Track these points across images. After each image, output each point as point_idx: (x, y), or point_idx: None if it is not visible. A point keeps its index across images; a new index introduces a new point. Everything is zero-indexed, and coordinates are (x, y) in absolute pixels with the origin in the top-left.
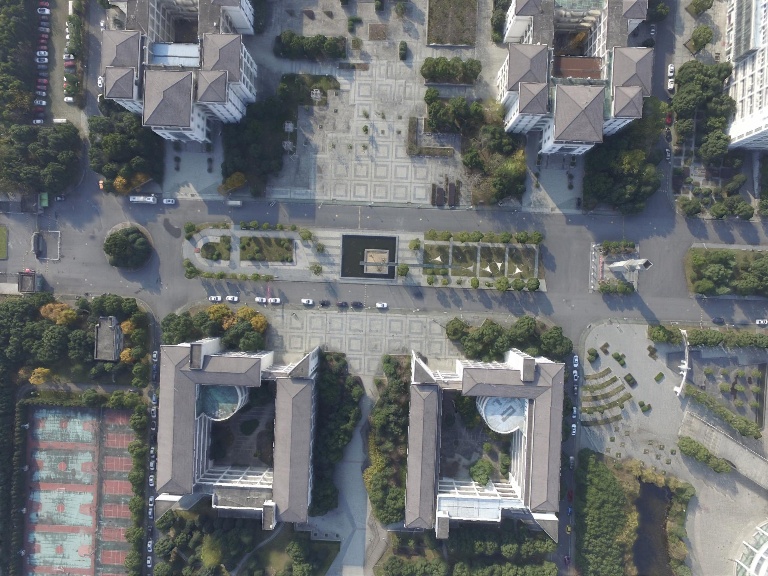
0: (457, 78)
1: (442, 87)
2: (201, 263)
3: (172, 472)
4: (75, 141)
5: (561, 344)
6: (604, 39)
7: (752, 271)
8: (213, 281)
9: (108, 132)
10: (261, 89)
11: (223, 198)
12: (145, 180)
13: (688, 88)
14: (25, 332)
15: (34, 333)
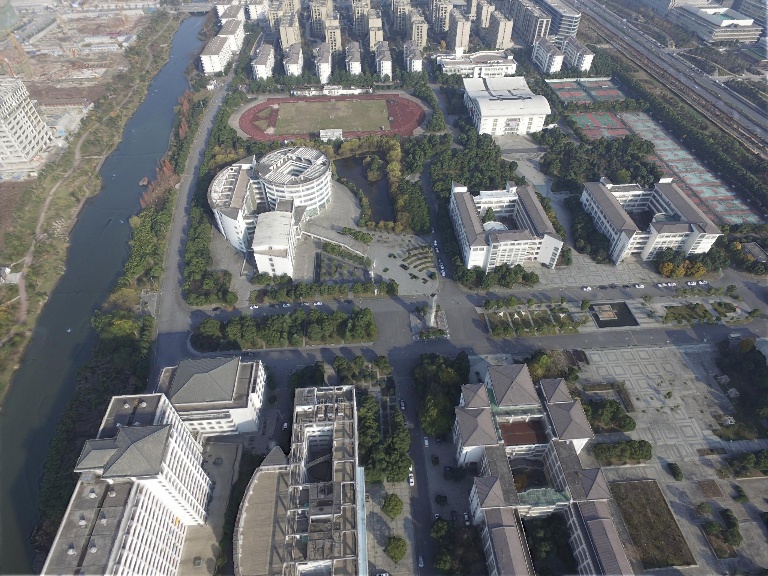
0: None
1: None
2: (729, 300)
3: (673, 187)
4: None
5: (464, 270)
6: None
7: (332, 325)
8: None
9: None
10: None
11: None
12: None
13: None
14: None
15: None
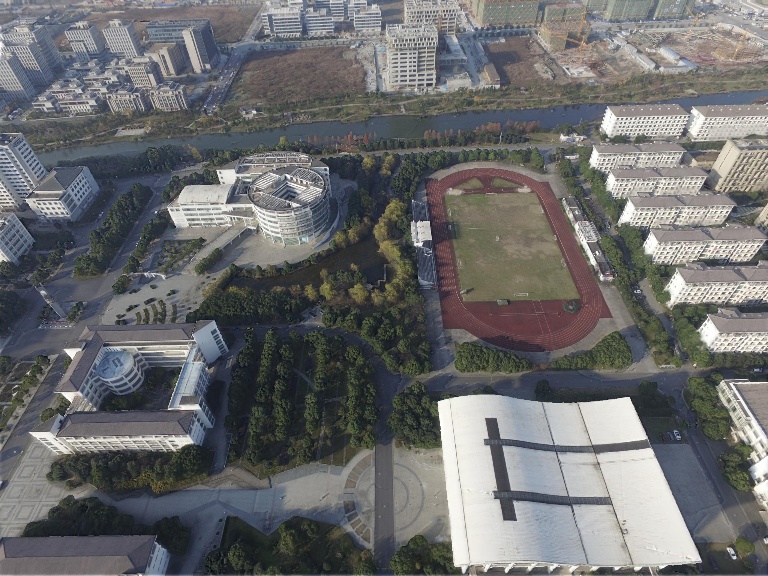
0: None
1: None
2: None
3: None
4: None
5: None
6: None
7: None
8: None
9: None
10: None
11: None
12: None
13: None
14: None
15: None
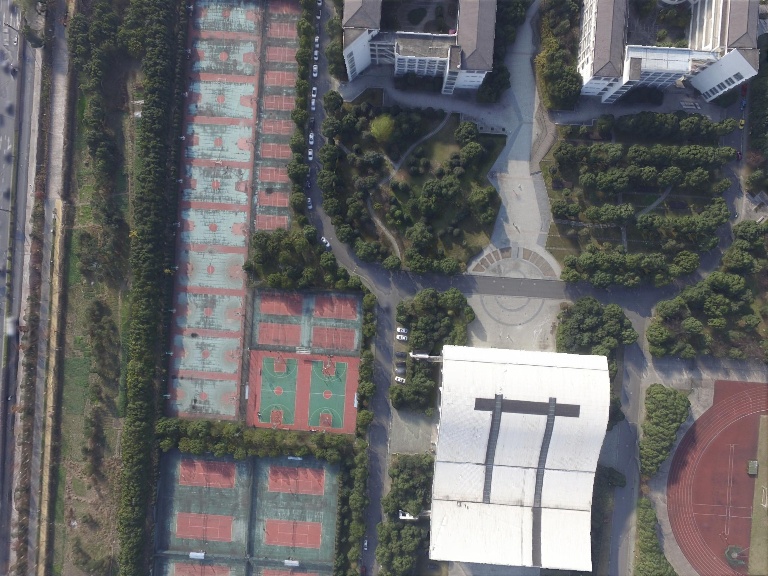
0: None
1: None
2: None
3: None
4: None
5: None
6: None
7: None
8: None
9: None
10: None
11: None
12: None
13: None
14: None
15: None
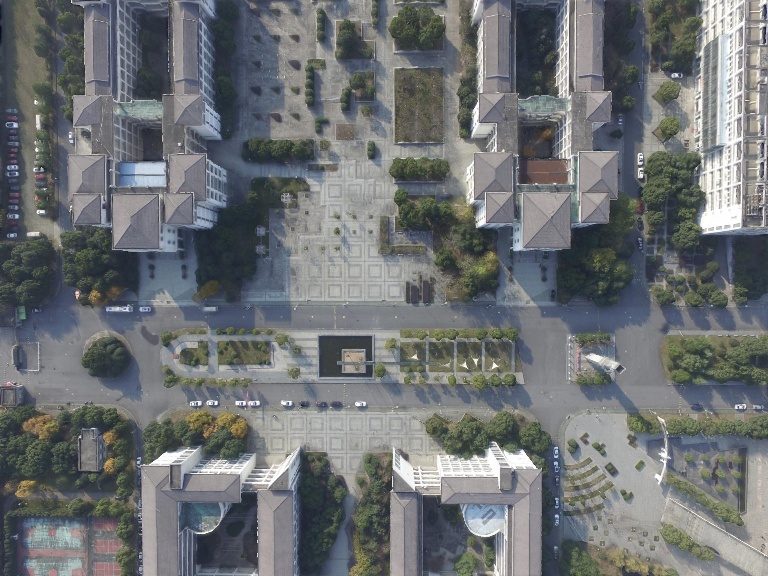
0: (426, 175)
1: (412, 185)
2: (180, 369)
3: None
4: (49, 253)
5: (539, 441)
6: (569, 141)
7: (728, 359)
8: (193, 386)
9: (81, 246)
10: (231, 194)
11: (199, 304)
12: (120, 292)
13: (657, 182)
14: (9, 448)
15: (18, 449)
